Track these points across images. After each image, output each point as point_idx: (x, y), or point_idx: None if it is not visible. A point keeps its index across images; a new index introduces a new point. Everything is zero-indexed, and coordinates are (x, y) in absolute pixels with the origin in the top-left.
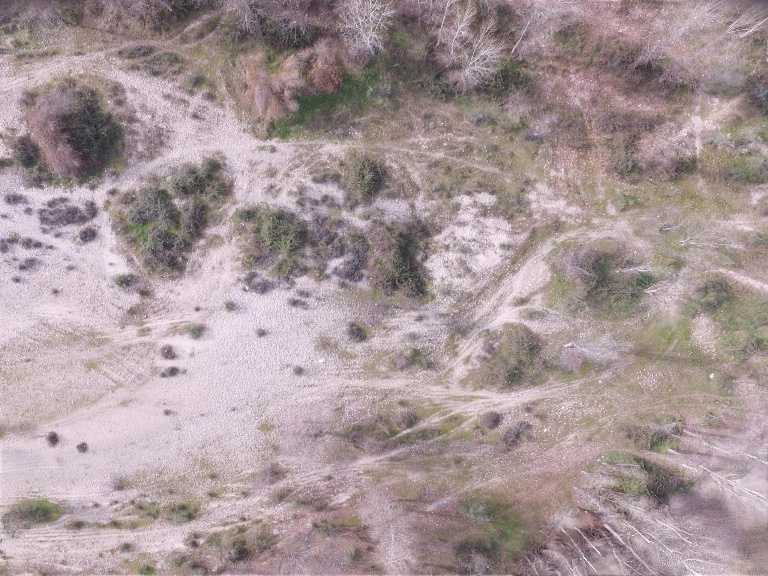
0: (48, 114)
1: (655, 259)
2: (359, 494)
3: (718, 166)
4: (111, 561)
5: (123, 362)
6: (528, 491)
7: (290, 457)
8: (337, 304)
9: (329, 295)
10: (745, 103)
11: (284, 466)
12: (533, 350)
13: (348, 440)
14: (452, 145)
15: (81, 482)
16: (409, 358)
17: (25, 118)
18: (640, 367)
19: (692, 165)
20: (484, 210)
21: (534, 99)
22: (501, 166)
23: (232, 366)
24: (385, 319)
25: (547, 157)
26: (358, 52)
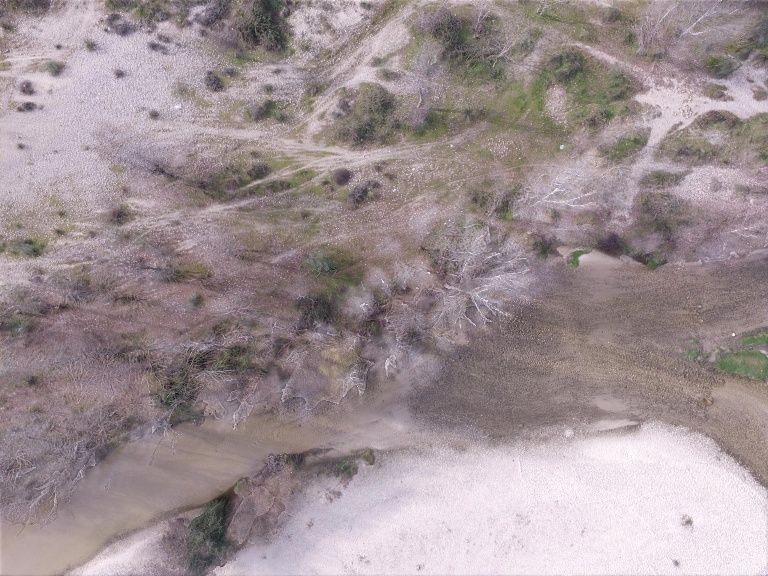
0: None
1: (513, 29)
2: (206, 242)
3: None
4: None
5: None
6: (373, 249)
7: (140, 200)
8: (197, 52)
9: (190, 42)
10: None
11: (134, 208)
12: (387, 110)
13: (198, 185)
14: None
15: None
16: (263, 108)
17: None
18: (492, 134)
19: None
20: None
21: None
22: None
23: (89, 105)
24: (244, 71)
25: None
26: None
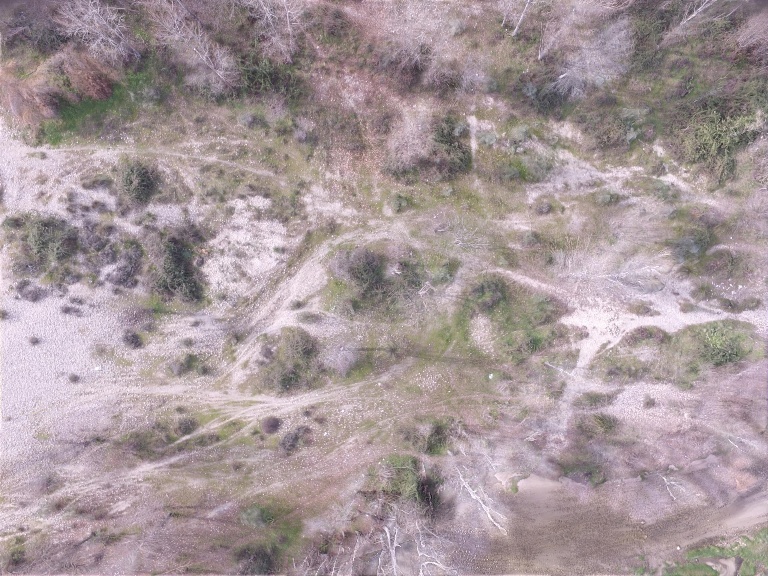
0: None
1: (432, 260)
2: (139, 502)
3: (493, 166)
4: None
5: None
6: (309, 495)
7: (68, 466)
8: (112, 311)
9: (104, 302)
10: (519, 102)
11: (62, 475)
12: (311, 354)
13: (125, 448)
14: (225, 149)
15: None
16: (184, 364)
17: None
18: (419, 369)
19: (464, 165)
20: (258, 214)
21: (308, 101)
22: (275, 169)
23: (6, 375)
24: (162, 325)
25: (321, 159)
26: (109, 57)
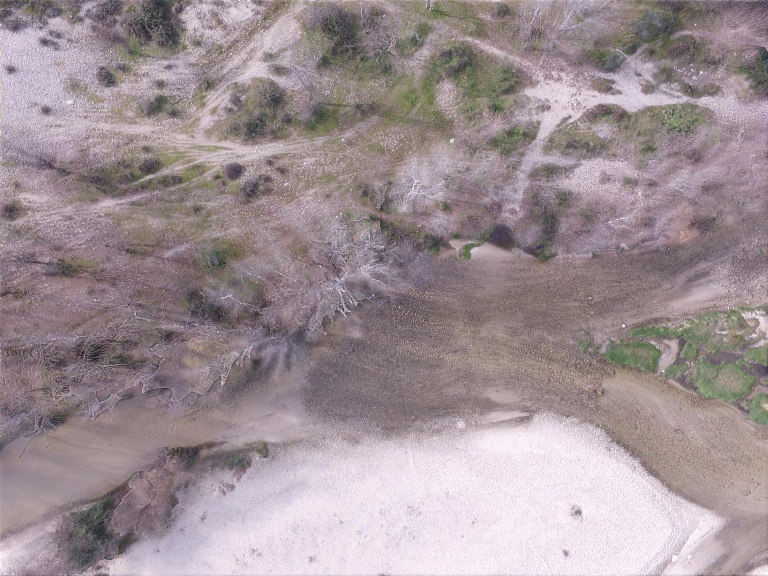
0: None
1: (403, 24)
2: (99, 236)
3: None
4: None
5: None
6: (265, 243)
7: (33, 195)
8: (89, 48)
9: (82, 38)
10: None
11: (26, 203)
12: (279, 105)
13: (89, 180)
14: None
15: None
16: (154, 103)
17: None
18: (383, 128)
19: None
20: None
21: None
22: None
23: None
24: (136, 66)
25: None
26: None
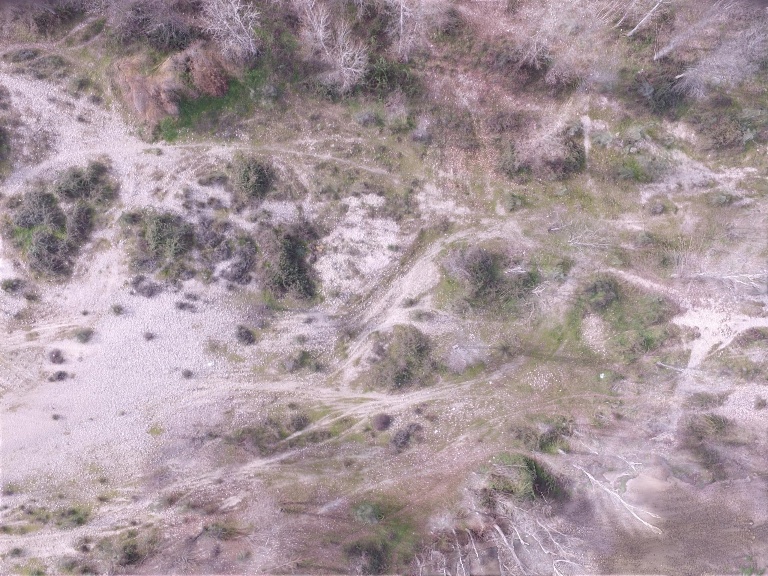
0: None
1: (544, 259)
2: (250, 497)
3: (607, 165)
4: (2, 566)
5: (11, 367)
6: (419, 493)
7: (180, 461)
8: (226, 307)
9: (217, 298)
10: (633, 102)
11: (174, 470)
12: (423, 351)
13: (237, 443)
14: (340, 146)
15: None
16: (298, 361)
17: None
18: (530, 368)
19: (579, 165)
20: (372, 211)
21: (422, 99)
22: (389, 167)
23: (120, 370)
24: (274, 322)
25: (435, 158)
26: (235, 54)
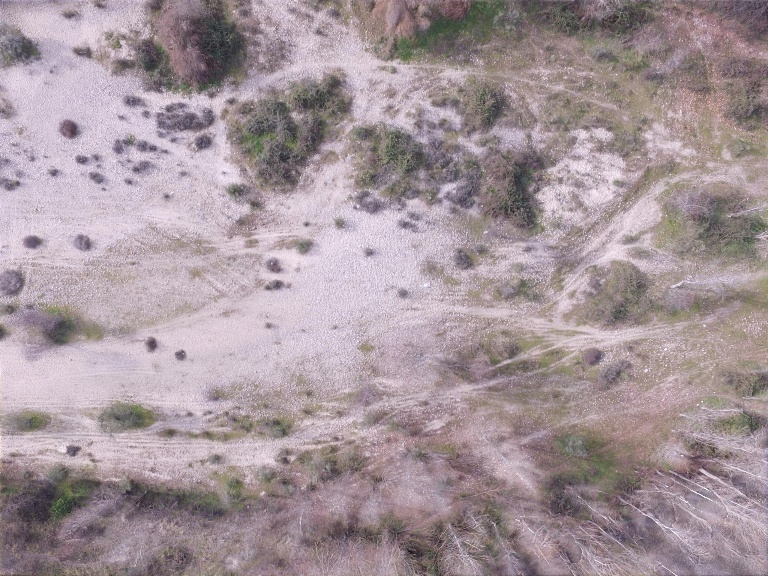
0: (178, 15)
1: (767, 207)
2: (454, 422)
3: None
4: (200, 472)
5: (228, 272)
6: (625, 431)
7: (388, 380)
8: (446, 229)
9: (439, 220)
10: None
11: (381, 388)
12: (639, 289)
13: (448, 366)
14: (572, 79)
15: (177, 390)
16: (515, 288)
17: (149, 22)
18: (745, 314)
19: None
20: (600, 145)
21: (656, 39)
22: (619, 103)
23: (337, 283)
24: (493, 248)
25: (666, 98)
26: None
